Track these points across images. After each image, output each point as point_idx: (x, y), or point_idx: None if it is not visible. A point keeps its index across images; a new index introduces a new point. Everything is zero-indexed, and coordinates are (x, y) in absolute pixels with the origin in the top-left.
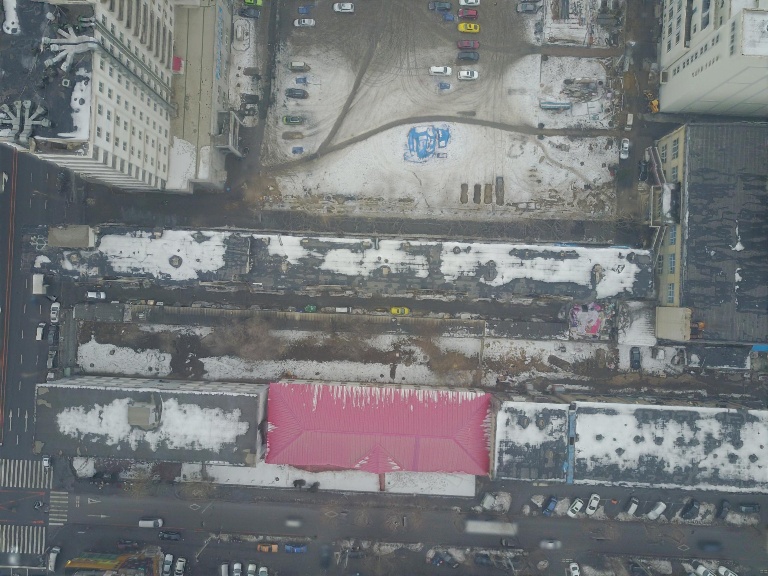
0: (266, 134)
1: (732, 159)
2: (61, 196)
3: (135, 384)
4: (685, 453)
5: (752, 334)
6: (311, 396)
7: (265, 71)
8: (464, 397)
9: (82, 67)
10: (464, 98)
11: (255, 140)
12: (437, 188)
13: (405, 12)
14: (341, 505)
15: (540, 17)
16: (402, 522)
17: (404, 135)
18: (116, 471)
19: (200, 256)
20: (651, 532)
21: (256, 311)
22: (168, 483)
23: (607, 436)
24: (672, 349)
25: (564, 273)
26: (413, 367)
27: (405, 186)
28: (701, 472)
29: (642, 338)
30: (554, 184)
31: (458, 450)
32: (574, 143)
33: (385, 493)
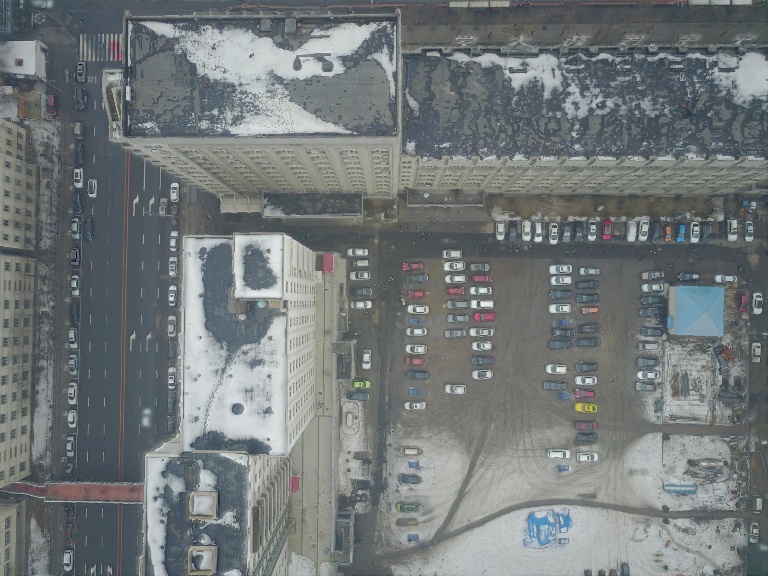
0: (379, 521)
1: None
2: None
3: None
4: None
5: None
6: None
7: (376, 455)
8: None
9: None
10: (584, 480)
11: (368, 527)
12: (560, 575)
13: (519, 391)
14: None
15: (660, 395)
16: None
17: (523, 520)
18: None
19: None
20: None
21: None
22: None
23: None
24: None
25: None
26: None
27: (526, 574)
28: None
29: None
30: (681, 569)
31: None
32: (701, 527)
33: None
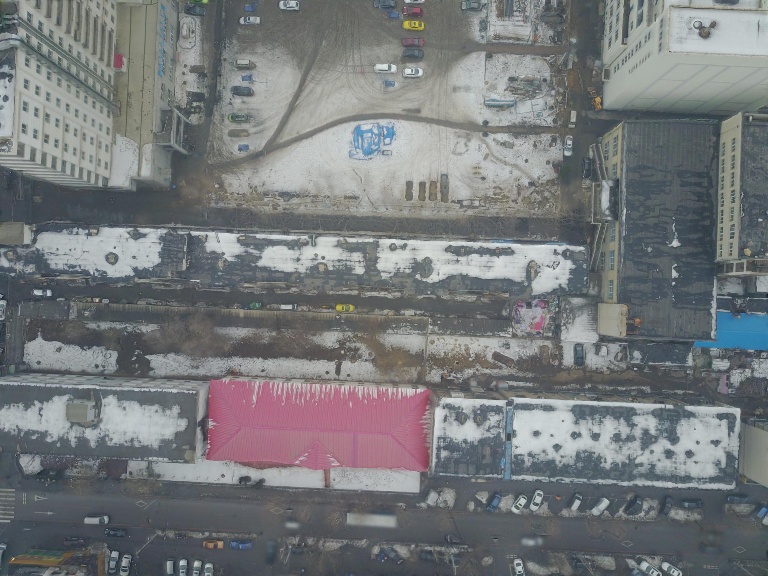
0: (212, 132)
1: (669, 156)
2: (8, 194)
3: (78, 381)
4: (622, 449)
5: (689, 330)
6: (251, 393)
7: (211, 69)
8: (404, 393)
9: (6, 64)
10: (409, 95)
11: (201, 138)
12: (382, 185)
13: (350, 10)
14: (287, 502)
15: (485, 15)
16: (345, 518)
17: (349, 132)
18: (62, 468)
19: (136, 253)
20: (592, 528)
21: (201, 308)
22: (114, 480)
23: (544, 432)
24: (615, 346)
25: (499, 270)
26: (358, 364)
27: (350, 183)
28: (638, 468)
29: (584, 335)
30: (498, 181)
31: (396, 446)
32: (518, 140)
33: (330, 490)
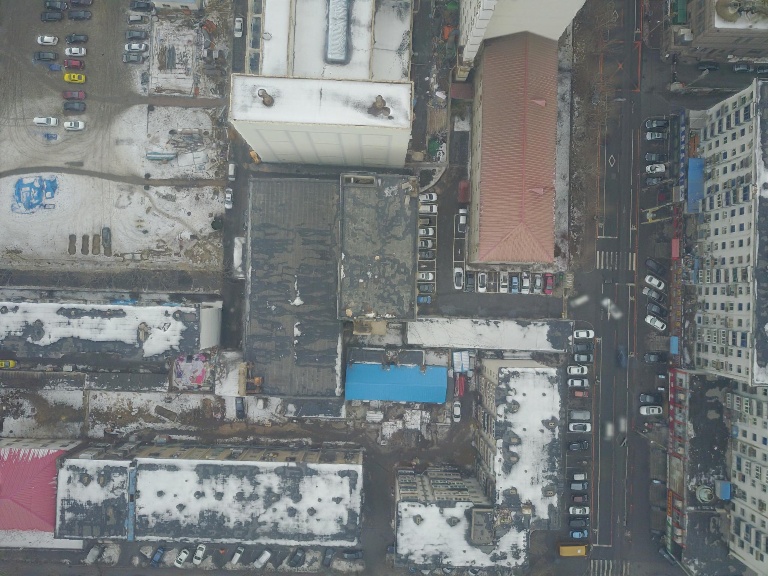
0: None
1: (291, 214)
2: None
3: None
4: (245, 508)
5: (312, 388)
6: None
7: None
8: (35, 454)
9: None
10: (72, 149)
11: None
12: (45, 239)
13: (12, 62)
14: None
15: (146, 67)
16: None
17: (12, 186)
18: None
19: None
20: None
21: None
22: None
23: (168, 492)
24: (276, 398)
25: (110, 332)
26: (21, 420)
27: (13, 238)
28: (261, 526)
29: (237, 389)
30: (161, 234)
31: (20, 509)
32: (179, 193)
33: None
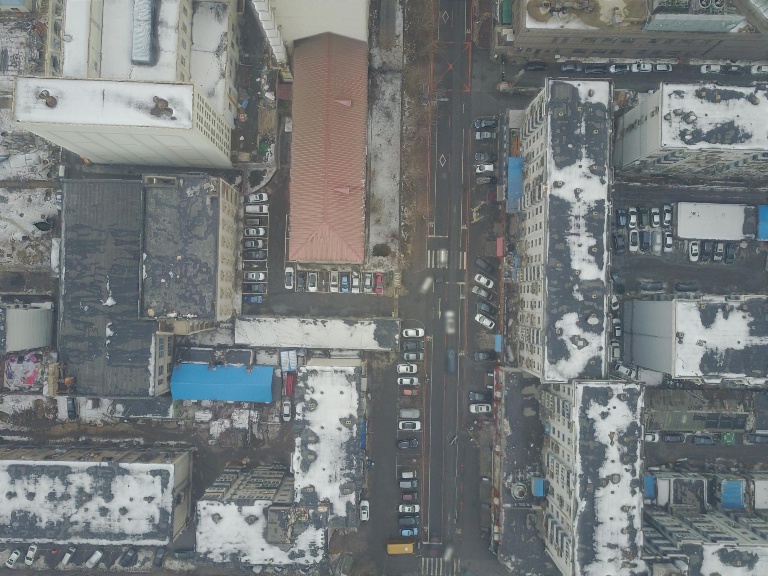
0: None
1: (103, 215)
2: None
3: None
4: (56, 508)
5: (124, 388)
6: None
7: None
8: None
9: None
10: None
11: None
12: None
13: None
14: None
15: None
16: None
17: None
18: None
19: None
20: None
21: None
22: None
23: None
24: None
25: None
26: None
27: None
28: (72, 526)
29: None
30: None
31: None
32: (11, 195)
33: None
